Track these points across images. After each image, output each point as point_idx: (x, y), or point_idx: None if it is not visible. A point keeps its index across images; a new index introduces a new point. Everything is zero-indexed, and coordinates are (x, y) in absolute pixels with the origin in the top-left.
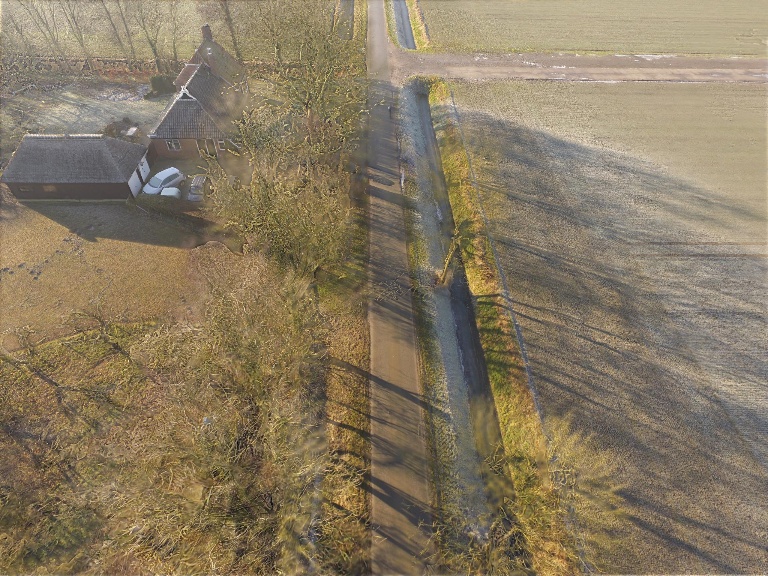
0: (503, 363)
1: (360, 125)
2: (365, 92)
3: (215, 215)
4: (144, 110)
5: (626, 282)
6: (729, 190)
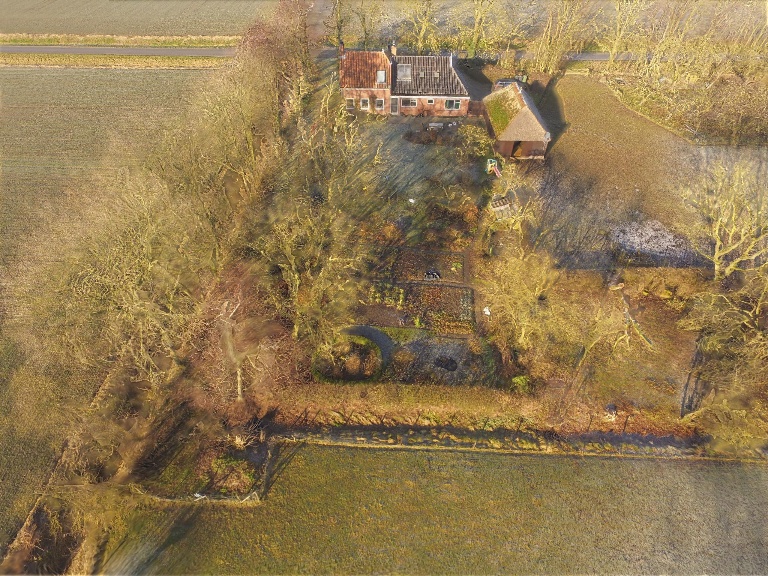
0: (589, 44)
1: None
2: None
3: (544, 79)
4: (384, 132)
5: None
6: None
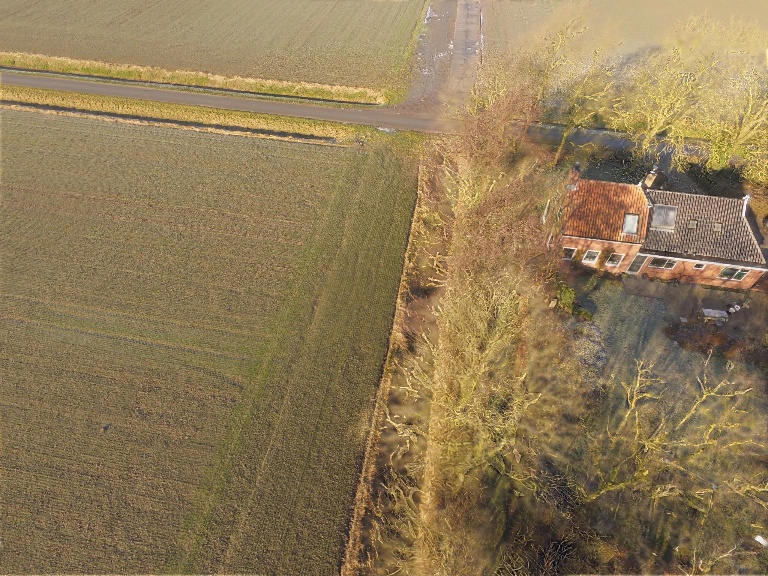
0: None
1: (601, 152)
2: (518, 141)
3: None
4: (628, 316)
5: (762, 95)
6: (641, 47)
